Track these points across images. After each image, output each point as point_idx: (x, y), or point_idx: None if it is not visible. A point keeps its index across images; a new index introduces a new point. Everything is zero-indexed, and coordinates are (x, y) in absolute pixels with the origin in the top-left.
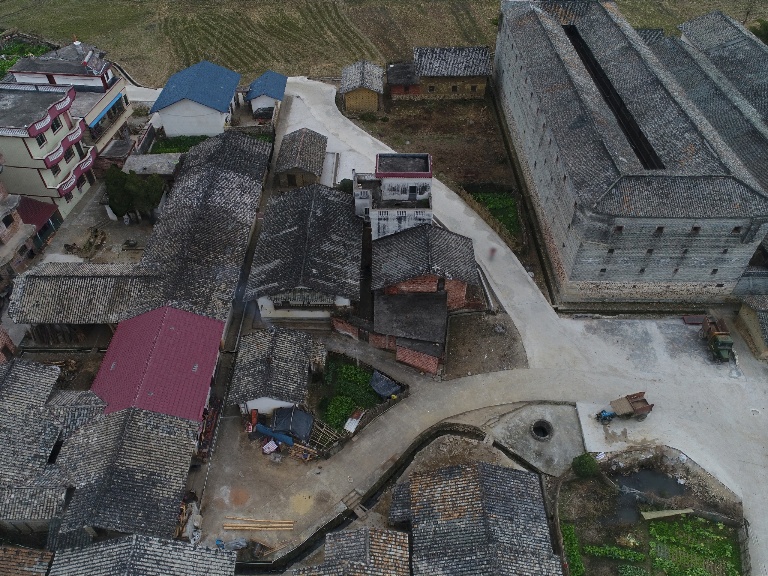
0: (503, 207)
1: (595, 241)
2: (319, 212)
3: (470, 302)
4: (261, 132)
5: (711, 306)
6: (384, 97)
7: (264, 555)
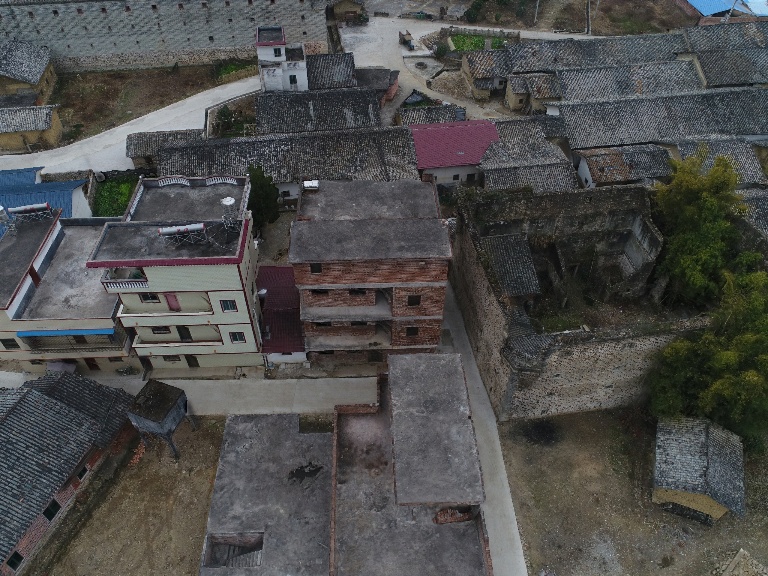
0: None
1: (326, 4)
2: None
3: None
4: (95, 187)
5: None
6: None
7: None
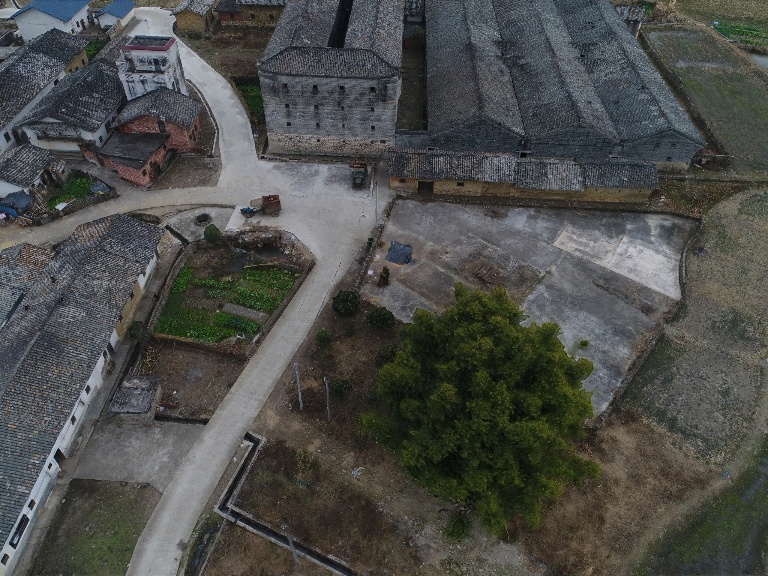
0: None
1: (270, 96)
2: (90, 78)
3: (194, 147)
4: (99, 41)
5: (383, 160)
6: (217, 23)
7: None
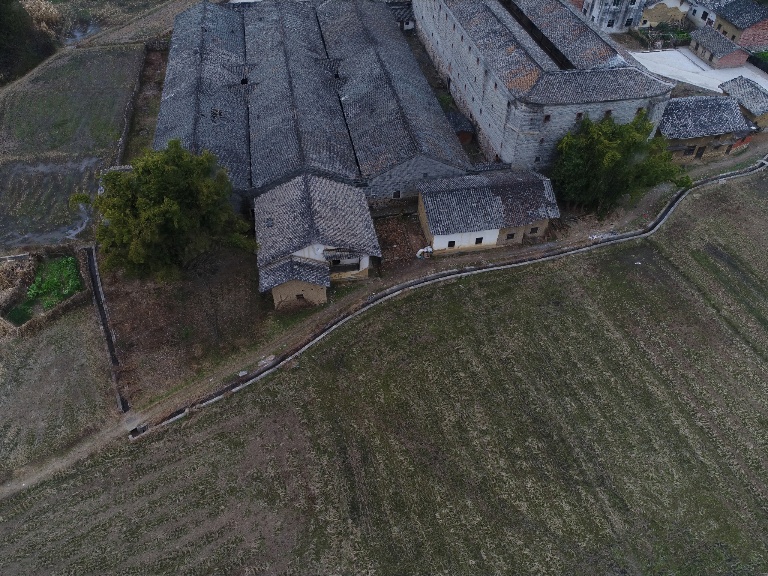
0: None
1: None
2: None
3: None
4: None
5: None
6: None
7: None
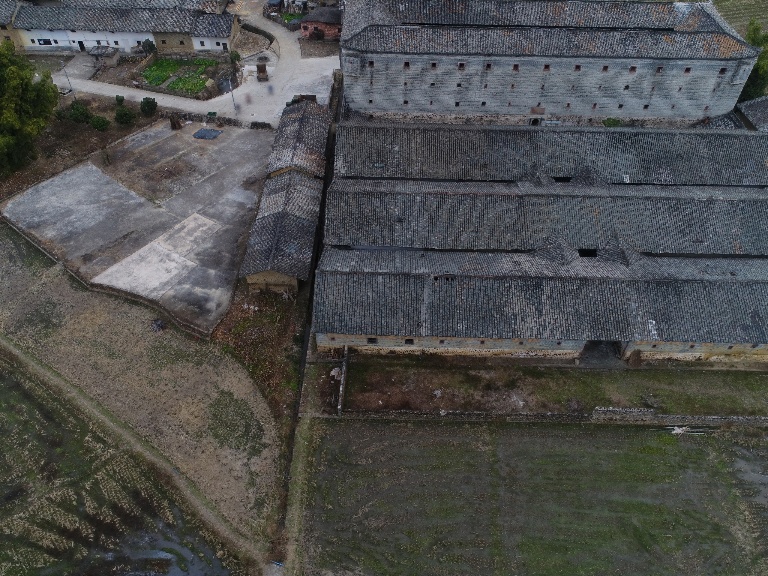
0: None
1: None
2: None
3: None
4: None
5: None
6: None
7: (228, 7)
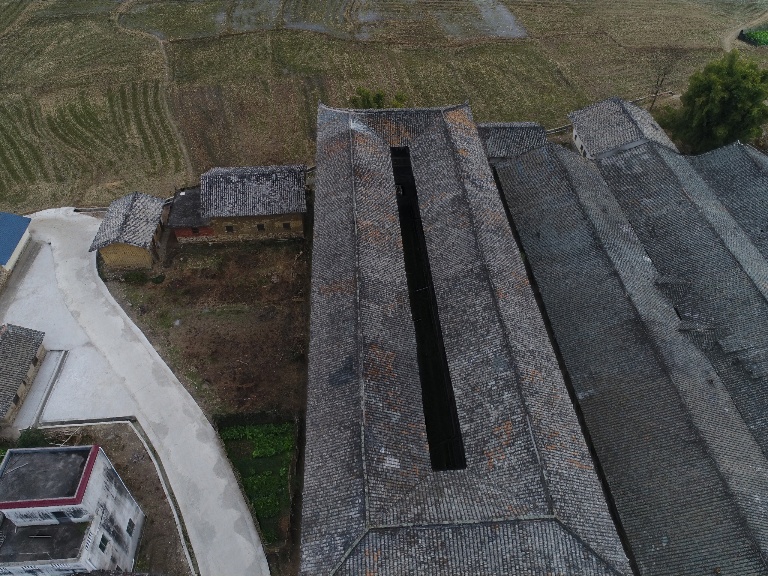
0: (276, 452)
1: None
2: None
3: None
4: None
5: None
6: (170, 238)
7: None
